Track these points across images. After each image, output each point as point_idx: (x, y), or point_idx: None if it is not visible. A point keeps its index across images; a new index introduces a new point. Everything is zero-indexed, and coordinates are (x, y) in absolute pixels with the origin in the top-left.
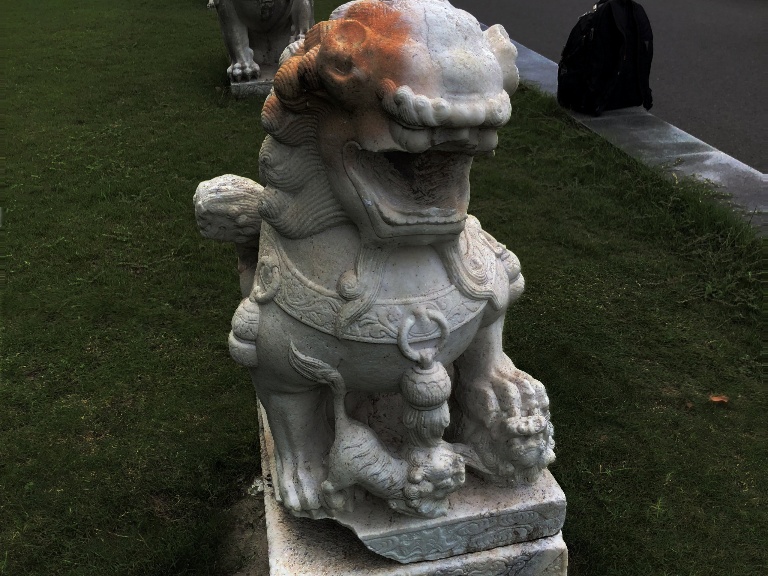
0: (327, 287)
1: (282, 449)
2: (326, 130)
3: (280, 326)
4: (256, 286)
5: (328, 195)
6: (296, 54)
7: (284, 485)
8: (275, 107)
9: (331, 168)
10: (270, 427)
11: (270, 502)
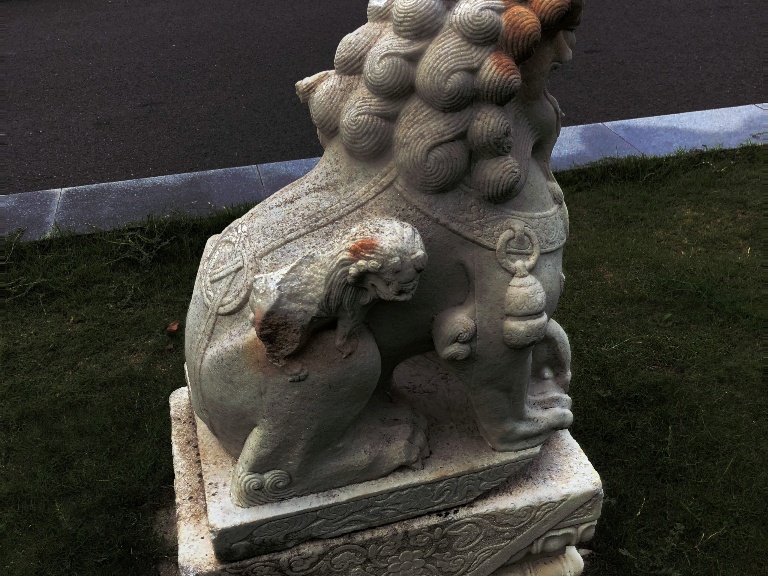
0: (552, 206)
1: (524, 408)
2: (541, 64)
3: (553, 268)
4: (517, 263)
5: (527, 131)
6: (508, 7)
7: (560, 413)
8: (516, 66)
9: (536, 101)
10: (507, 408)
11: (483, 506)
